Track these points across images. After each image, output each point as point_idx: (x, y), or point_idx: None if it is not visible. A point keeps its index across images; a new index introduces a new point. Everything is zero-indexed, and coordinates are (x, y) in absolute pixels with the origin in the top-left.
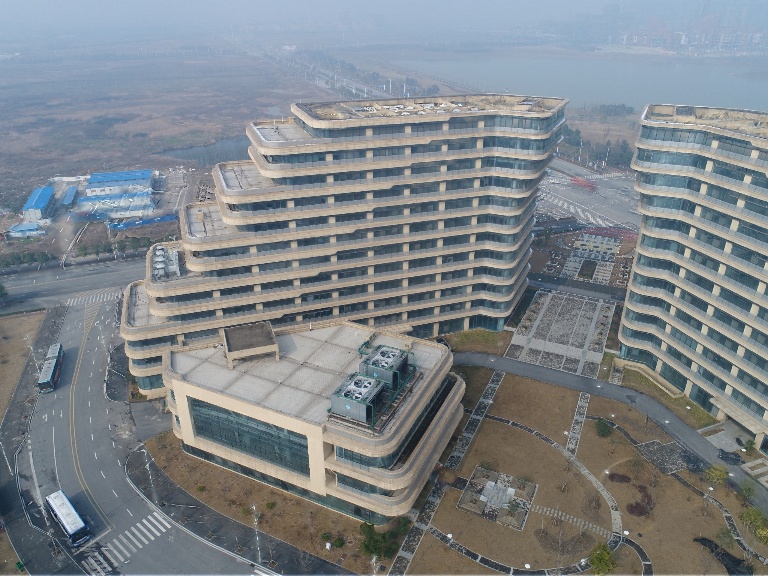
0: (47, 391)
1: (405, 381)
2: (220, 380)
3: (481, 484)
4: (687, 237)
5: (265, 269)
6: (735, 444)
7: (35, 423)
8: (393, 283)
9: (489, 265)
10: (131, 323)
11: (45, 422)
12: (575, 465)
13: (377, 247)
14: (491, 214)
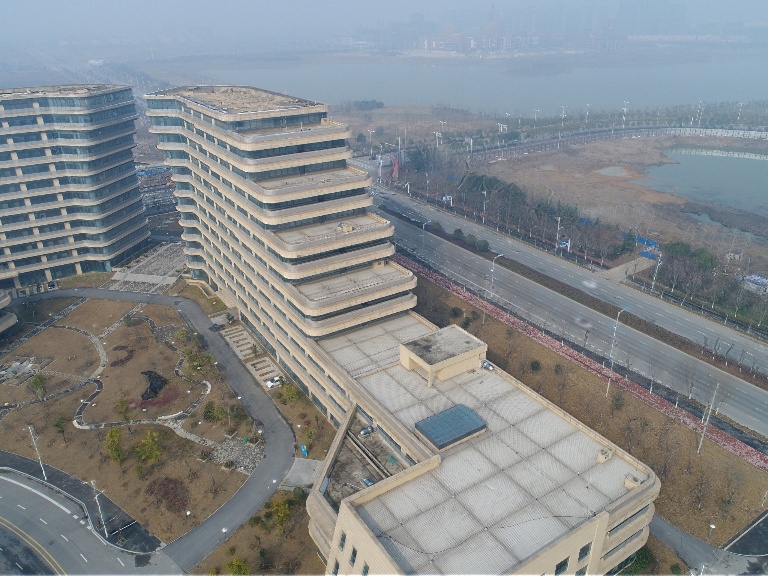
0: None
1: None
2: None
3: (9, 365)
4: (192, 178)
5: None
6: (228, 320)
7: None
8: None
9: (81, 218)
10: None
11: None
12: (95, 346)
13: None
14: (69, 176)
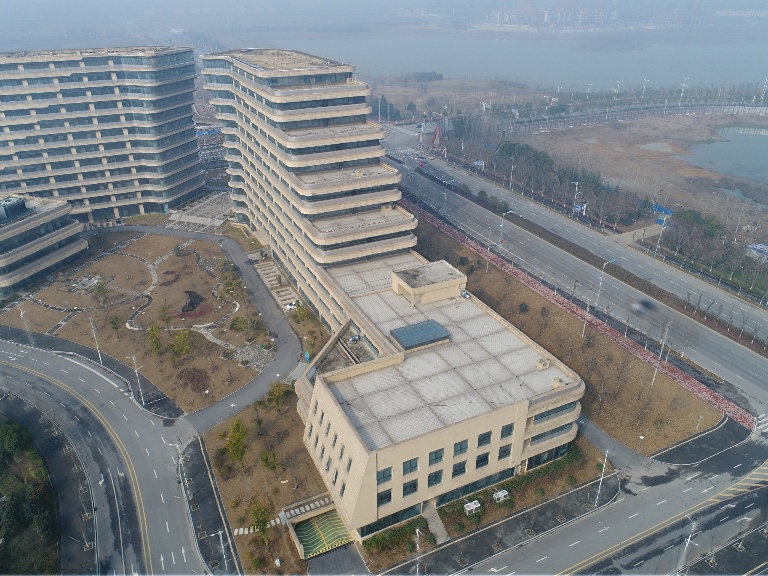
0: None
1: (19, 215)
2: None
3: (80, 280)
4: (238, 131)
5: None
6: None
7: None
8: (70, 177)
9: (145, 164)
10: None
11: None
12: (149, 270)
13: (49, 150)
14: (136, 127)
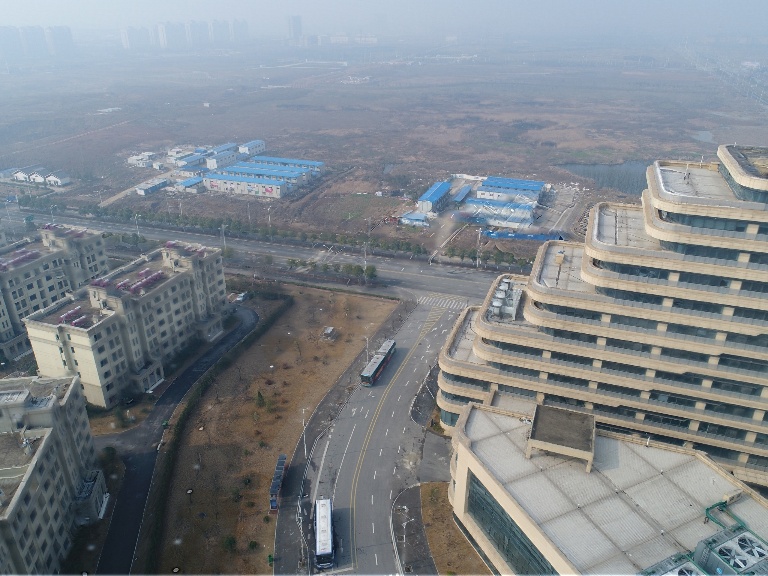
0: (366, 385)
1: None
2: (509, 467)
3: None
4: None
5: (614, 345)
6: None
7: (344, 413)
8: None
9: None
10: (451, 352)
11: (352, 416)
12: None
13: None
14: None
